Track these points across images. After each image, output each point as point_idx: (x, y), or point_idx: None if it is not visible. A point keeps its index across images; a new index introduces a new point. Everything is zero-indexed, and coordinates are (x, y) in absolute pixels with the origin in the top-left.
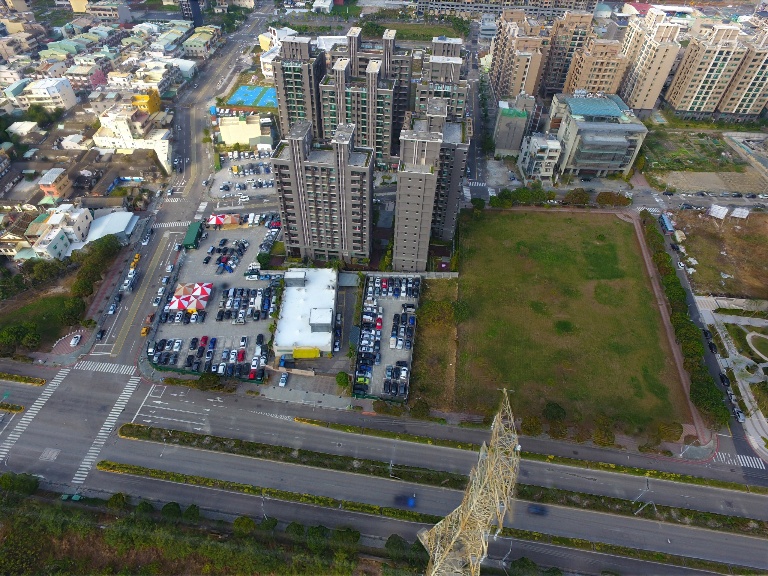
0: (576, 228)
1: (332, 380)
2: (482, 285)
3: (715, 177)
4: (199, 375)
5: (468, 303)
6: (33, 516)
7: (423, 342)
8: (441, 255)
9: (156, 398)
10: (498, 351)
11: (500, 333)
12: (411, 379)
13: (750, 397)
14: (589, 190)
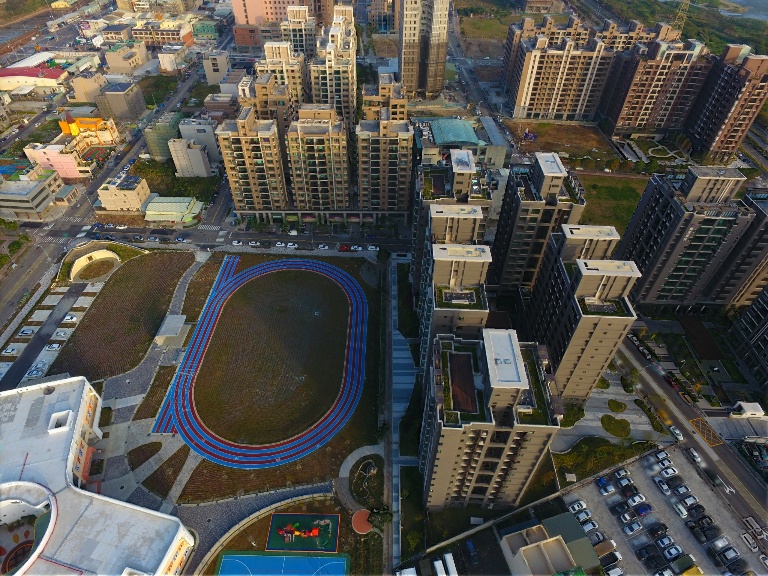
0: None
1: None
2: None
3: None
4: None
5: None
6: None
7: None
8: None
9: None
10: None
11: None
12: None
13: None
14: None
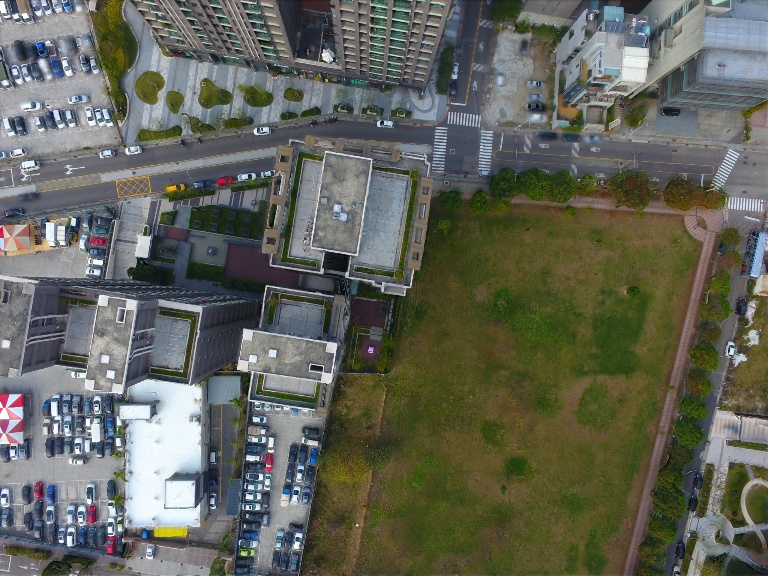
0: (603, 255)
1: (210, 550)
2: (422, 389)
3: None
4: (46, 543)
5: (396, 424)
6: None
7: (326, 489)
8: (370, 324)
9: (4, 573)
10: (419, 510)
11: (428, 480)
12: (305, 550)
13: (696, 574)
14: (665, 143)
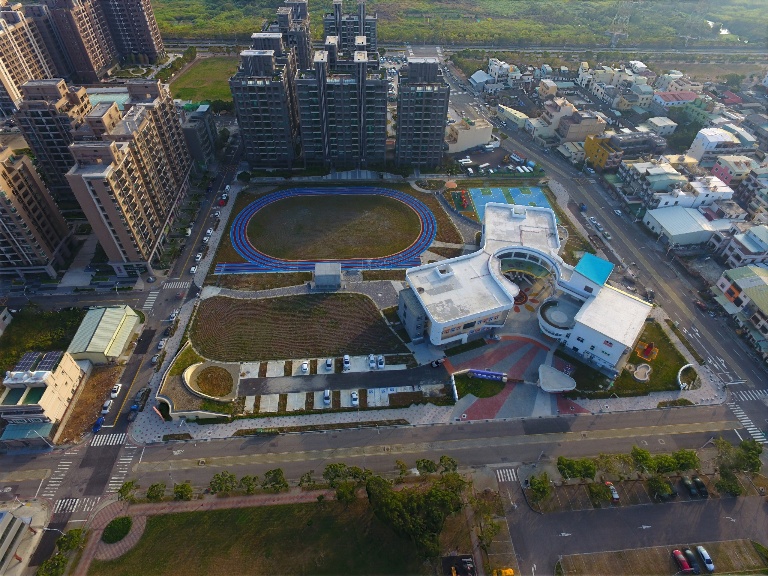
0: None
1: None
2: None
3: (10, 145)
4: None
5: None
6: (410, 35)
7: None
8: None
9: None
10: None
11: None
12: None
13: None
14: None
